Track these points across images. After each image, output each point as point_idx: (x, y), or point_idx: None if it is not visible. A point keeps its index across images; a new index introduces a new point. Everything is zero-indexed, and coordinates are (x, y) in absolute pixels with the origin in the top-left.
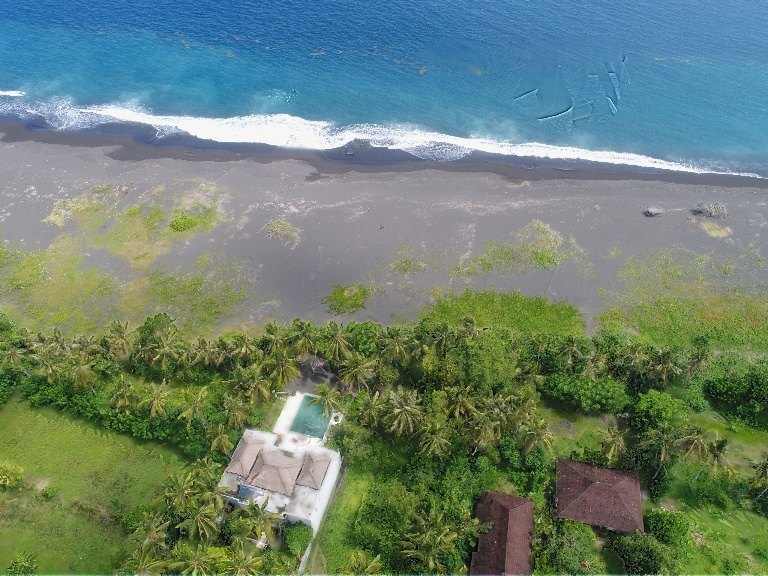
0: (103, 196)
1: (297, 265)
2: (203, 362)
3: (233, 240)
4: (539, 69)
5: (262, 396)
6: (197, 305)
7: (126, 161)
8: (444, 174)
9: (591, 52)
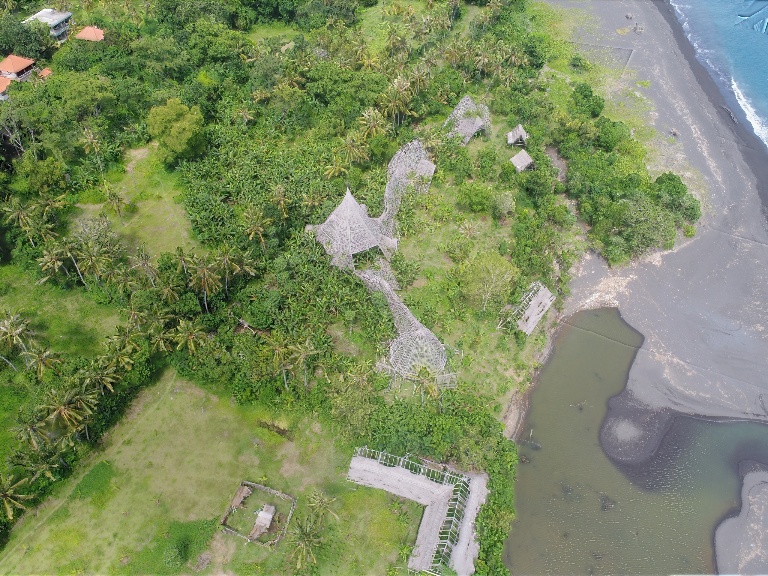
0: None
1: None
2: None
3: None
4: None
5: None
6: None
7: None
8: None
9: None
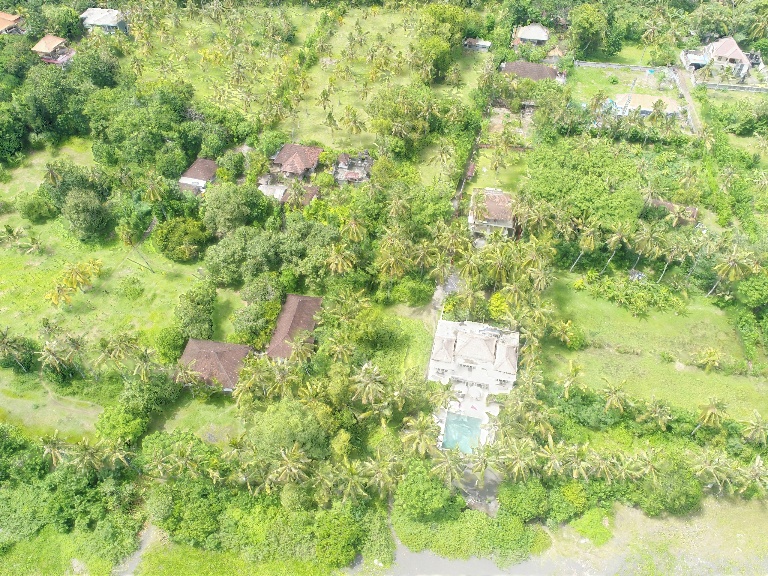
0: None
1: None
2: None
3: None
4: None
5: None
6: None
7: None
8: None
9: None
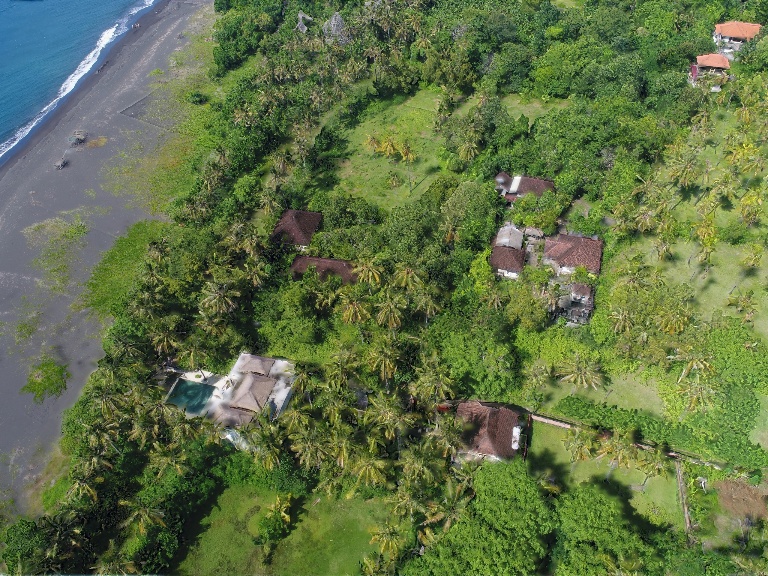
0: None
1: None
2: None
3: None
4: None
5: None
6: None
7: None
8: None
9: None
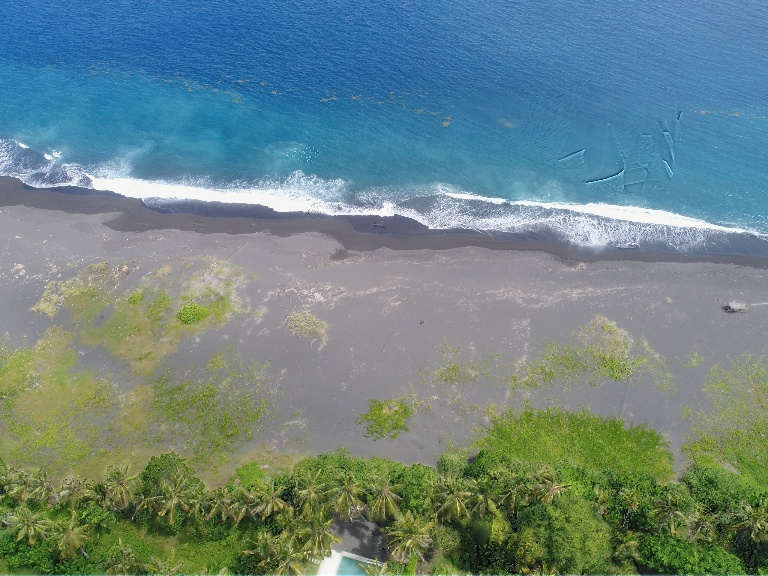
0: (101, 277)
1: (326, 371)
2: (219, 513)
3: (250, 337)
4: (586, 128)
5: (294, 574)
6: (209, 424)
7: (127, 232)
8: (487, 253)
9: (644, 109)
